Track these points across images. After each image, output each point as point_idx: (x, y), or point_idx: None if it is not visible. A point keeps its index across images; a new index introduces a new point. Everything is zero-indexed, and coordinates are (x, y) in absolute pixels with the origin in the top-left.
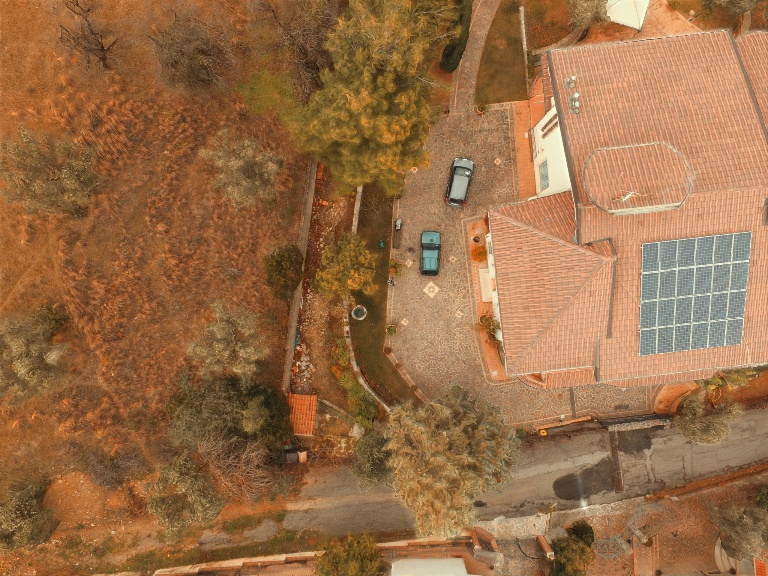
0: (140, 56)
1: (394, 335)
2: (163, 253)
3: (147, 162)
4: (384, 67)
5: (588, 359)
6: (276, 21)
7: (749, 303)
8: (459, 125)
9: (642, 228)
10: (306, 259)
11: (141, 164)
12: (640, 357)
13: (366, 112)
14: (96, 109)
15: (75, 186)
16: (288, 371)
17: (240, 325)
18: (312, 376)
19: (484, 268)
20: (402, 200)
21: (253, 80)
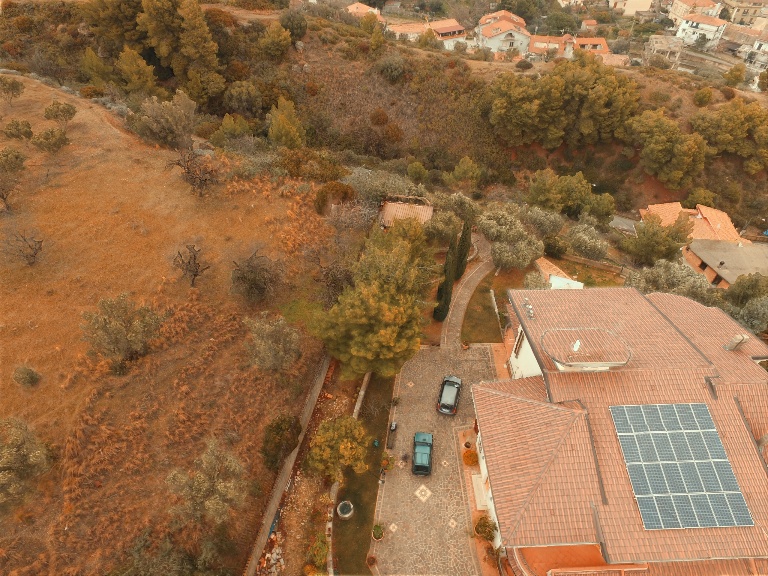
0: (219, 283)
1: (380, 543)
2: (176, 410)
3: (194, 344)
4: (390, 281)
5: (590, 532)
6: (319, 265)
7: (739, 477)
8: (449, 355)
9: (605, 393)
10: (302, 442)
11: (189, 344)
12: (647, 533)
13: (374, 298)
14: (173, 307)
15: (140, 330)
16: (255, 558)
17: (228, 460)
18: (280, 575)
19: (477, 474)
20: (398, 407)
21: (293, 304)
